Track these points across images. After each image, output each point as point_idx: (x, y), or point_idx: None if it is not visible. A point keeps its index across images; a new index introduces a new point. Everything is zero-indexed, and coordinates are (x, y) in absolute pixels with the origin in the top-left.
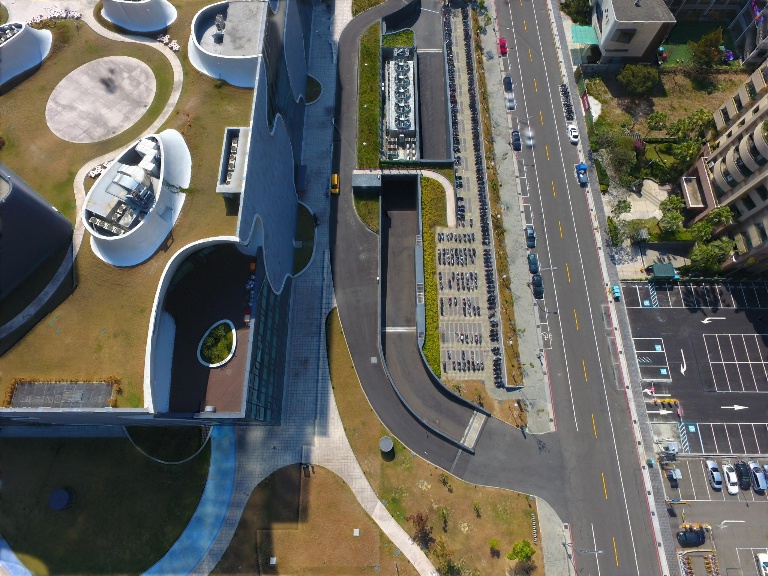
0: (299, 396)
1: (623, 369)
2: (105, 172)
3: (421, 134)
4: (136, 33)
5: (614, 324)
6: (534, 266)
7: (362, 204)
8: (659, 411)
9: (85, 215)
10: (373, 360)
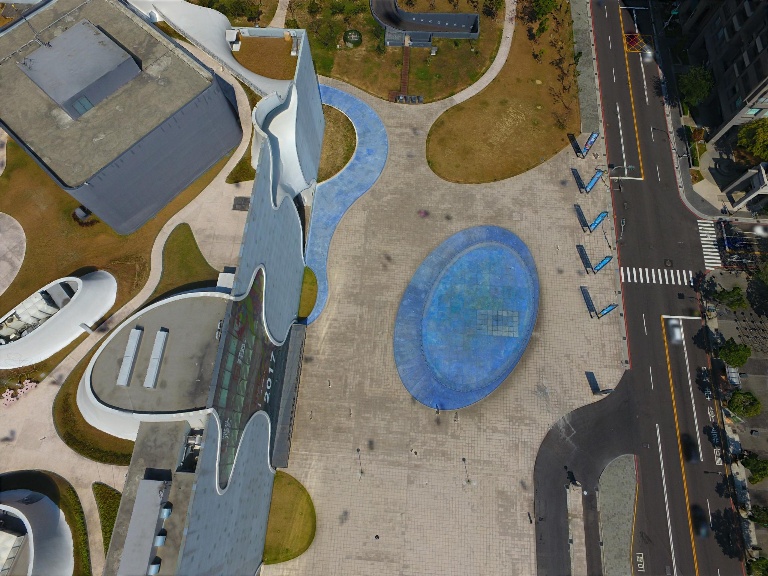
0: None
1: None
2: None
3: None
4: None
5: None
6: None
7: None
8: None
9: None
10: None
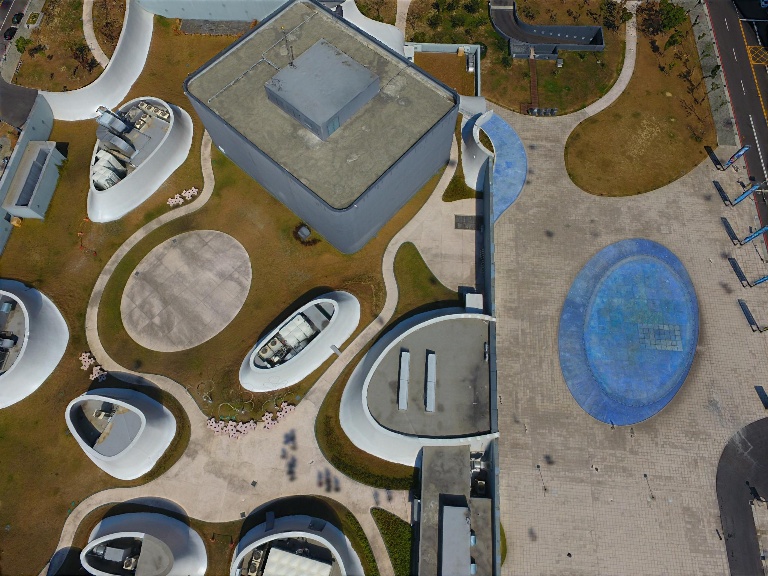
0: None
1: None
2: (150, 156)
3: None
4: (135, 388)
5: None
6: None
7: None
8: None
9: (171, 118)
10: None
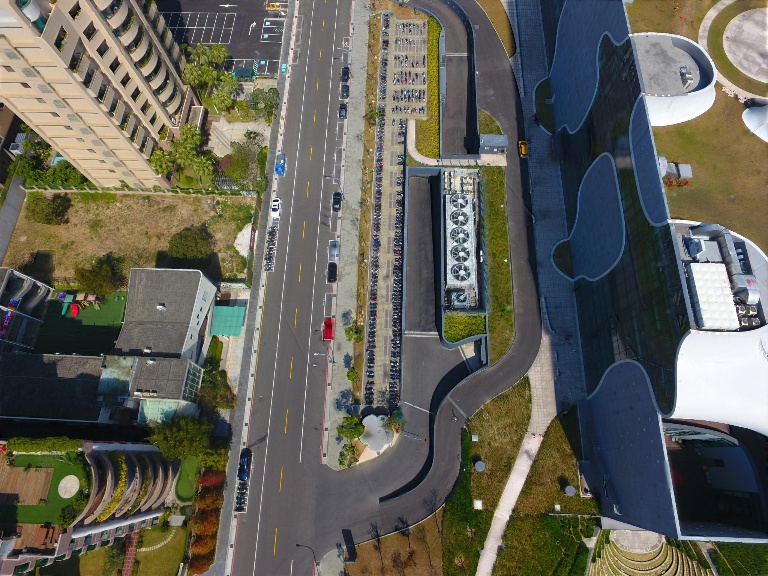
0: (529, 8)
1: (296, 26)
2: None
3: (433, 232)
4: None
5: (292, 52)
6: (344, 90)
7: (495, 132)
8: (280, 4)
9: None
10: (478, 27)
